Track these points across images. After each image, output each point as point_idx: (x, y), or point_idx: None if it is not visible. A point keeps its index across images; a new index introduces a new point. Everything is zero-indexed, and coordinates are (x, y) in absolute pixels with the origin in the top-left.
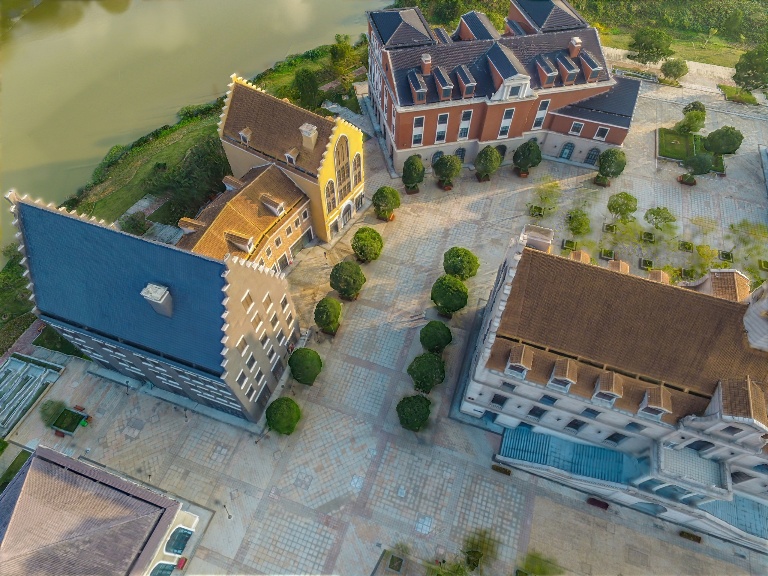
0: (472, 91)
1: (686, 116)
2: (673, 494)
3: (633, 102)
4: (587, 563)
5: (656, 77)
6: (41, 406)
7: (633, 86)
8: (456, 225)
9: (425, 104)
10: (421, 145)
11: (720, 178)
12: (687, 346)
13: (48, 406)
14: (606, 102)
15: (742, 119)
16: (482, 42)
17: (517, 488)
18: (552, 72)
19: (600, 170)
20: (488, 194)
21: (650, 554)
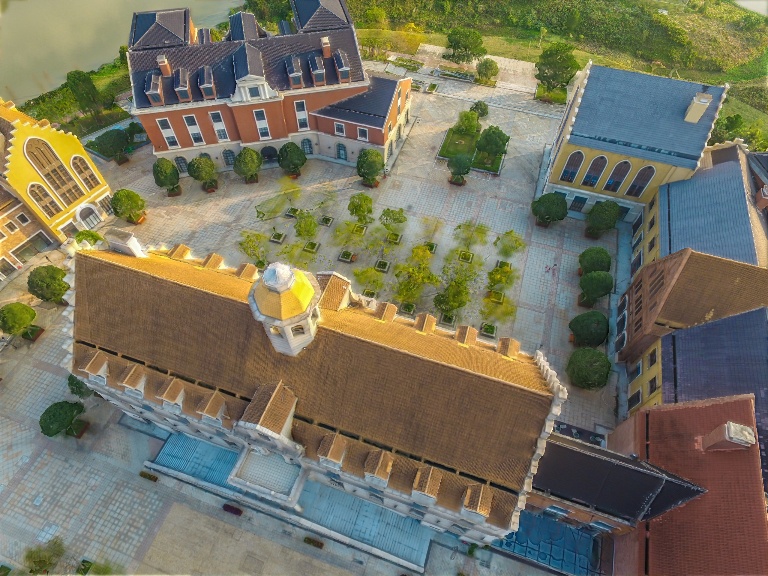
0: (212, 92)
1: (459, 116)
2: (271, 500)
3: (389, 102)
4: (199, 571)
5: (473, 77)
6: None
7: (390, 86)
8: (205, 227)
9: (163, 106)
10: (179, 147)
11: (493, 178)
12: (227, 351)
13: None
14: (363, 102)
15: (539, 118)
16: (230, 43)
17: (158, 495)
18: (293, 73)
19: (357, 171)
20: (251, 196)
21: (267, 561)
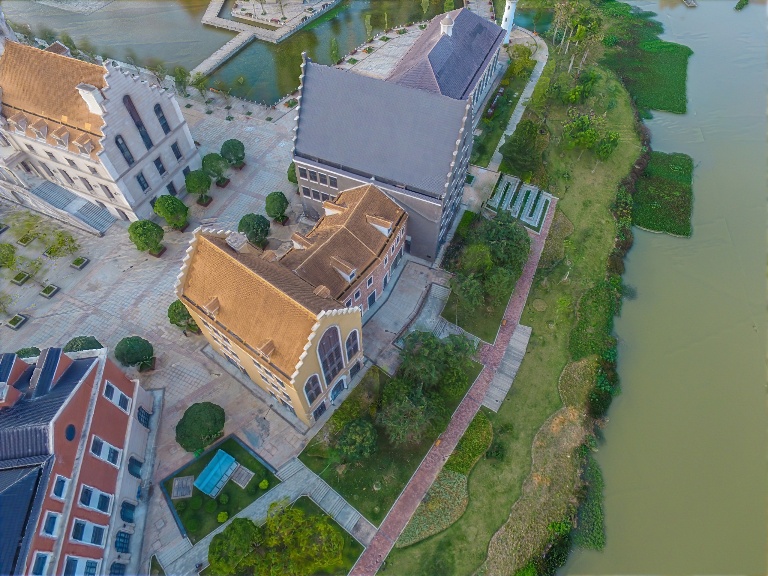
0: None
1: None
2: None
3: None
4: None
5: None
6: (489, 188)
7: None
8: (122, 310)
9: None
10: None
11: None
12: None
13: (484, 188)
14: None
15: None
16: None
17: None
18: None
19: None
20: None
21: None
